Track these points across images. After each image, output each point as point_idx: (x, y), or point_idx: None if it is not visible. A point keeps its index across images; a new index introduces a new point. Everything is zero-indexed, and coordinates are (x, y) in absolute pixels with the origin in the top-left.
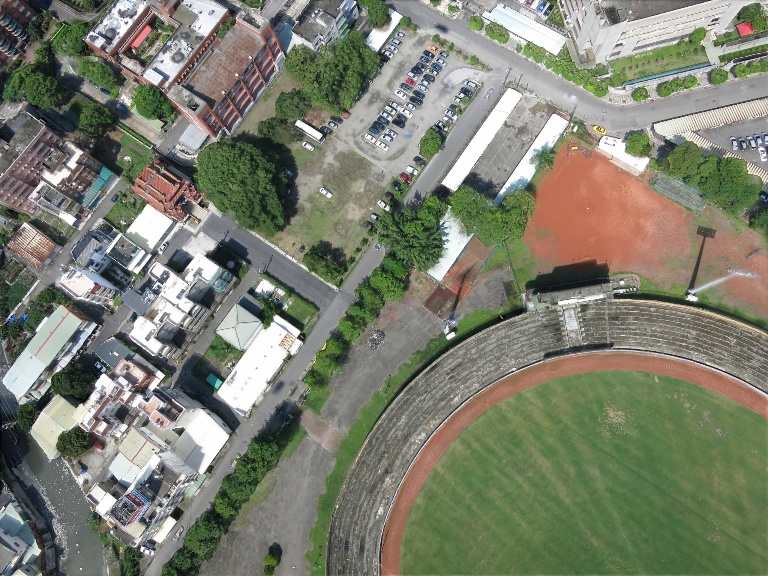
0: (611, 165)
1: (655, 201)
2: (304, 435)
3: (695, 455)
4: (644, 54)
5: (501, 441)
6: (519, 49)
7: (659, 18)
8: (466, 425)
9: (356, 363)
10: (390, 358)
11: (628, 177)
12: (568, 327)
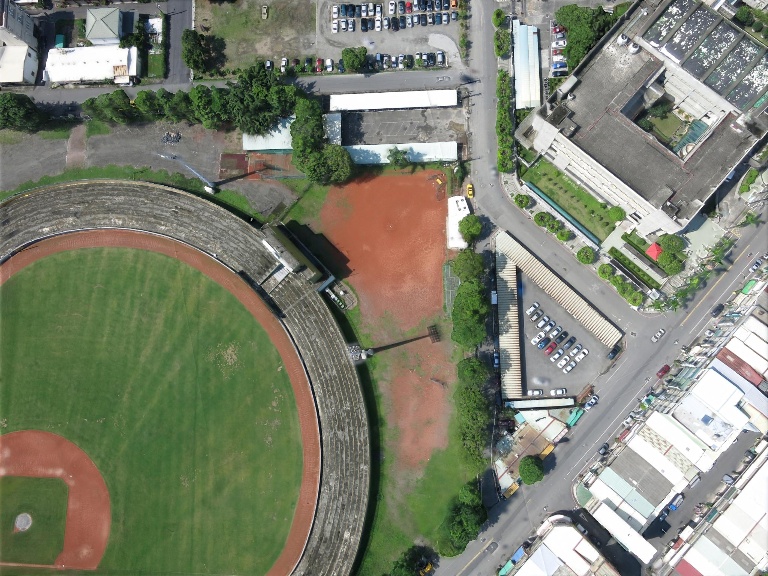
0: (444, 221)
1: (434, 276)
2: (66, 137)
3: (239, 432)
4: (571, 182)
5: (155, 283)
6: (500, 73)
7: (587, 158)
8: (150, 249)
9: (143, 136)
10: (164, 158)
11: (442, 241)
12: (276, 274)
